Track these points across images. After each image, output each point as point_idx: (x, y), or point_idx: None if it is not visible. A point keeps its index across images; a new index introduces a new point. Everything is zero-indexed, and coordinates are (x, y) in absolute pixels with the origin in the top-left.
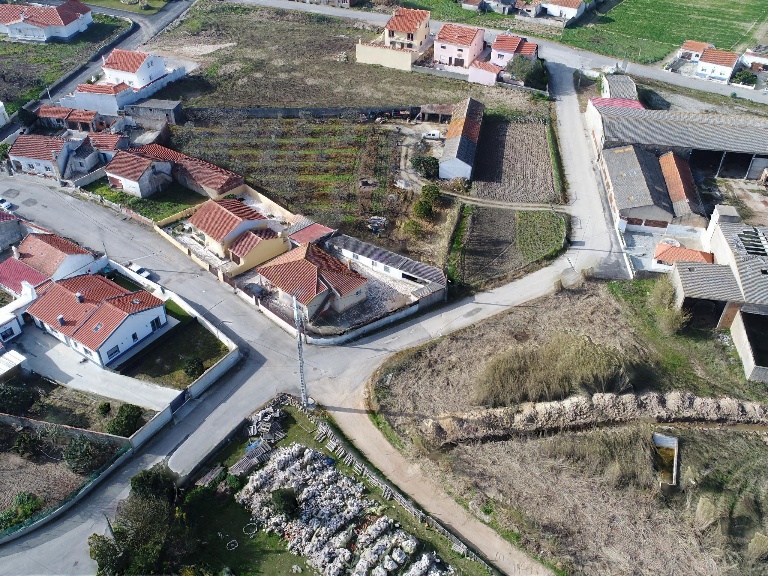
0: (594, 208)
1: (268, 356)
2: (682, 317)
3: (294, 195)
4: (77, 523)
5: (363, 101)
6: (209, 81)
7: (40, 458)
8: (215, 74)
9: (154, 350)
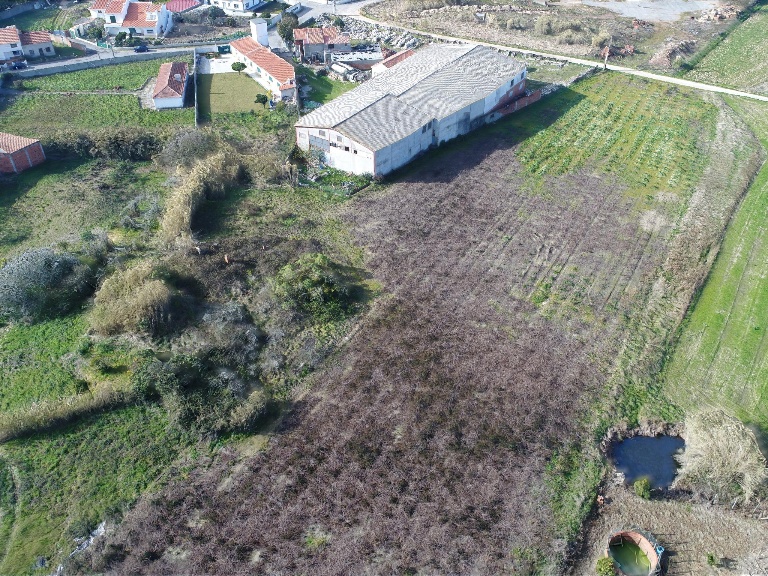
0: None
1: (313, 7)
2: None
3: None
4: None
5: None
6: None
7: (237, 27)
8: None
9: (263, 7)
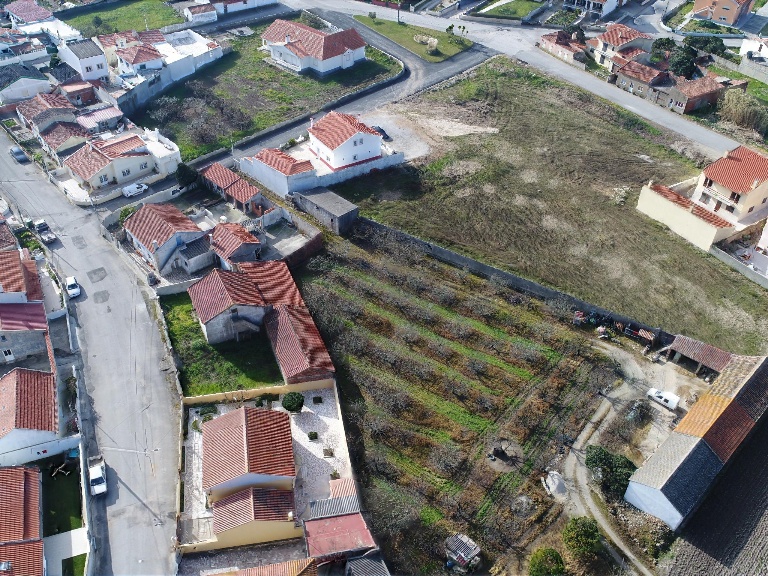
0: None
1: None
2: None
3: (389, 424)
4: None
5: (599, 285)
6: (422, 181)
7: None
8: (438, 171)
9: None
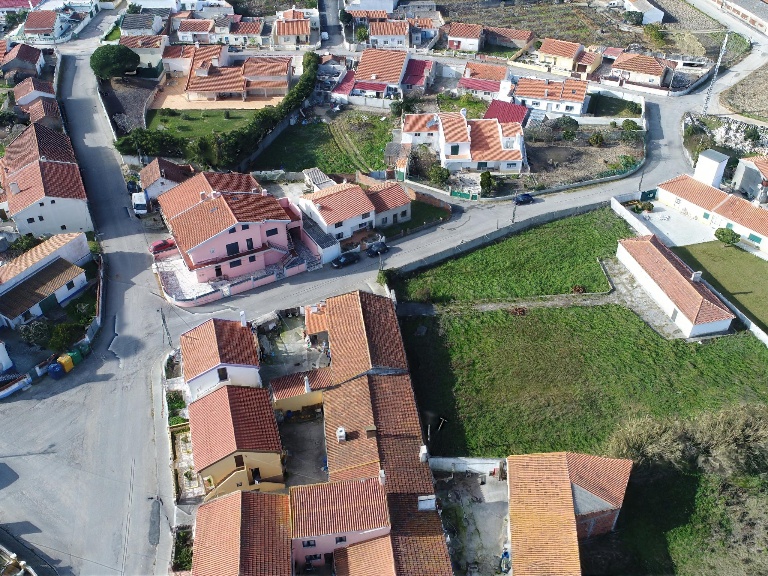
0: (745, 28)
1: (657, 103)
2: None
3: None
4: (657, 163)
5: None
6: None
7: (605, 146)
8: None
9: None
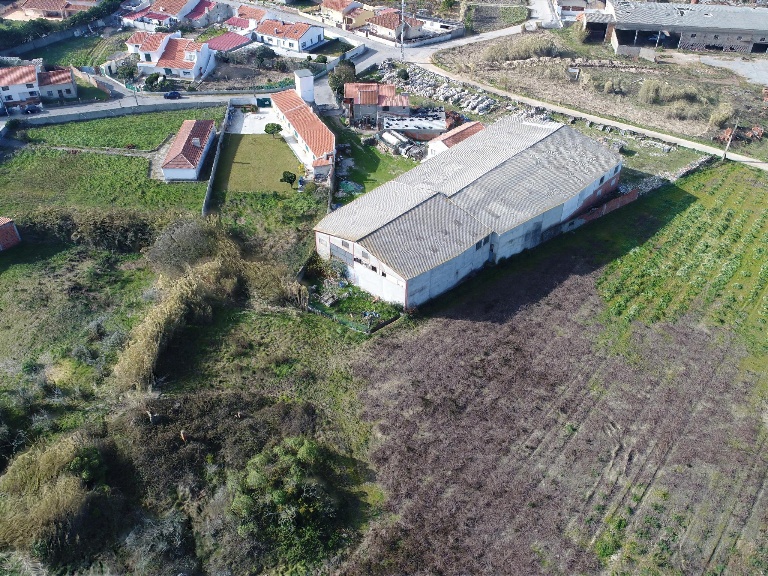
0: (544, 6)
1: (379, 50)
2: (586, 32)
3: (372, 3)
4: None
5: None
6: None
7: (286, 72)
8: None
9: (322, 47)
